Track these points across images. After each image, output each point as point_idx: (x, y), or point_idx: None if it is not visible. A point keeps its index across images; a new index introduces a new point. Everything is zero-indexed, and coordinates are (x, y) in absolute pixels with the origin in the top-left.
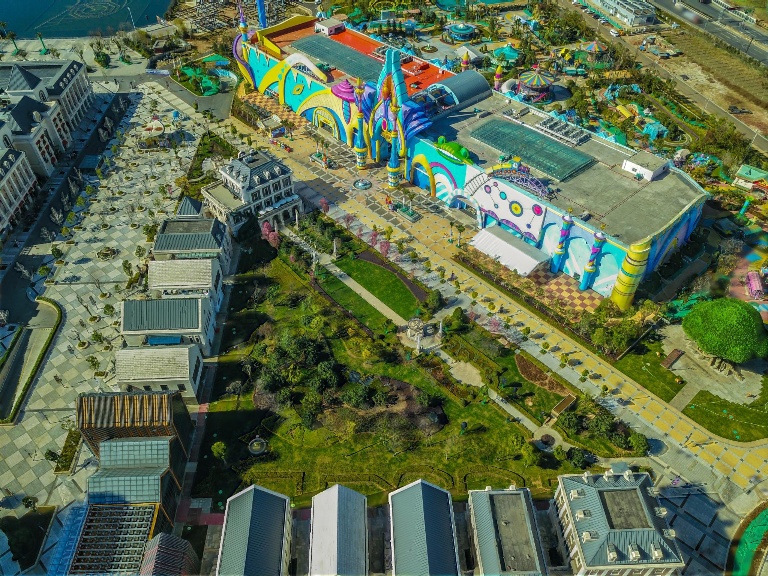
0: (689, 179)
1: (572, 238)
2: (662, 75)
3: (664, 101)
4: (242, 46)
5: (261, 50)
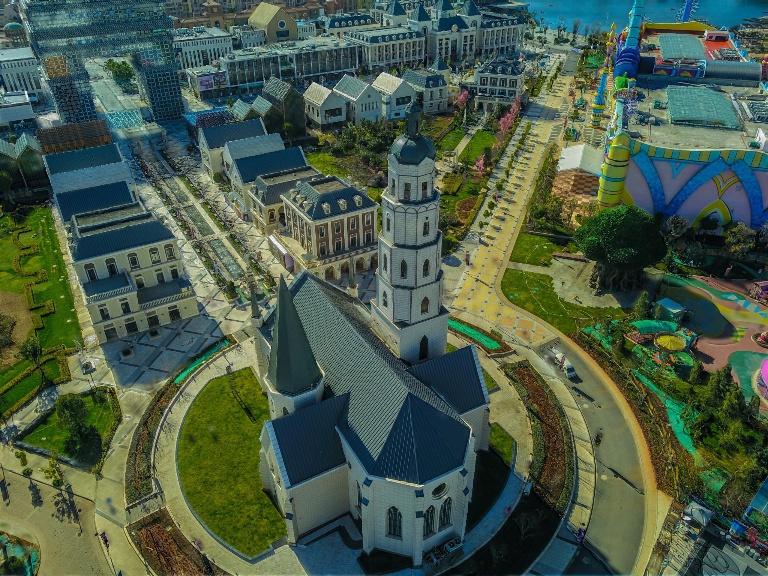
0: None
1: None
2: None
3: None
4: None
5: None
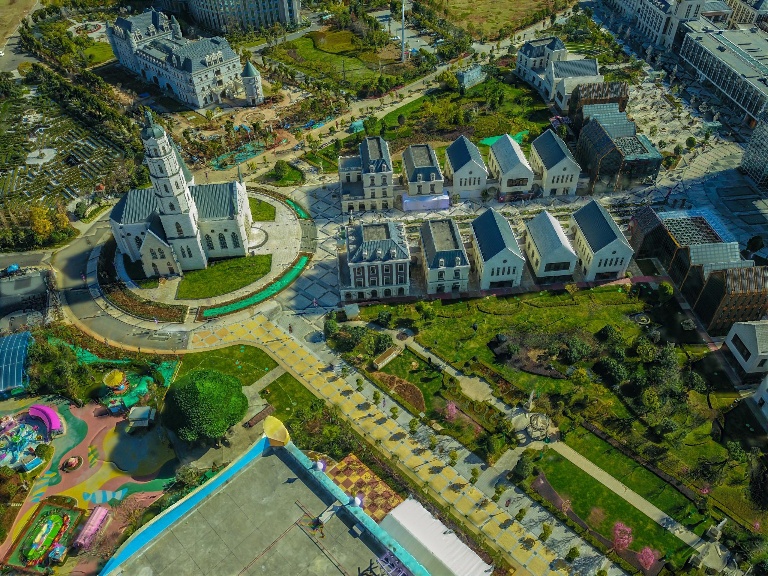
0: None
1: None
2: None
3: None
4: None
5: None
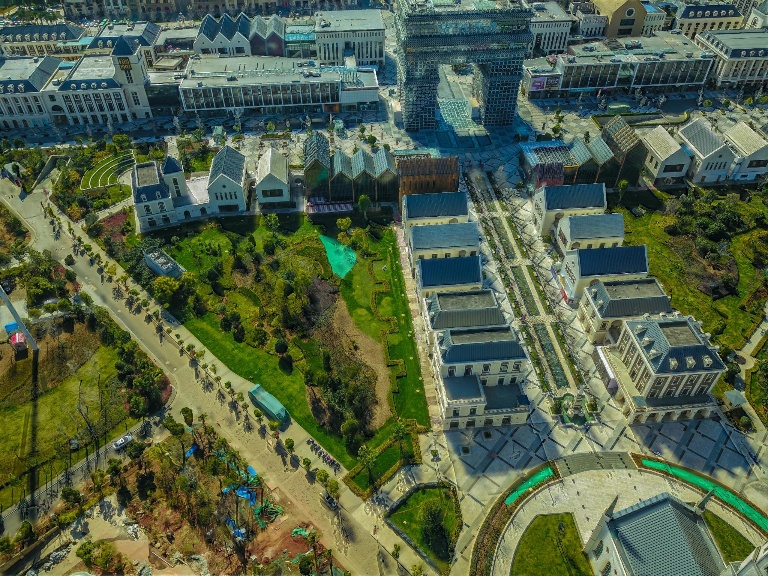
0: None
1: None
2: None
3: None
4: None
5: None
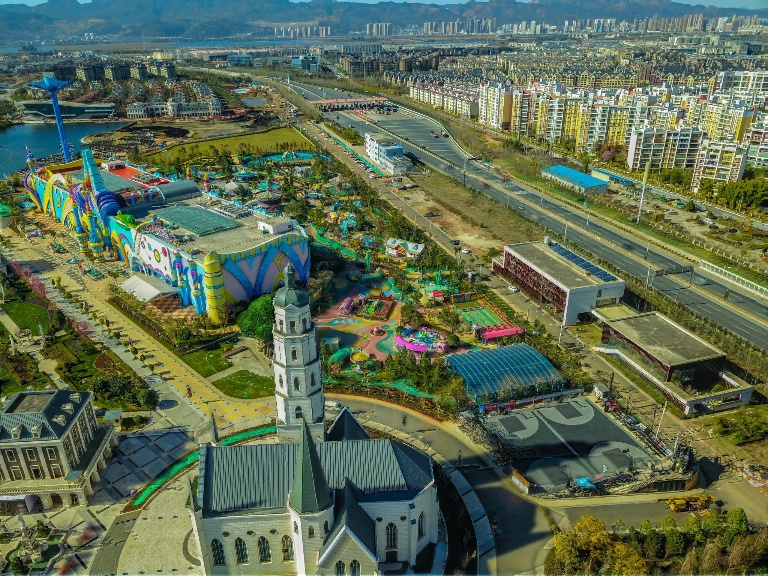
0: (301, 230)
1: (186, 270)
2: (389, 197)
3: (372, 209)
4: (30, 177)
5: (40, 177)
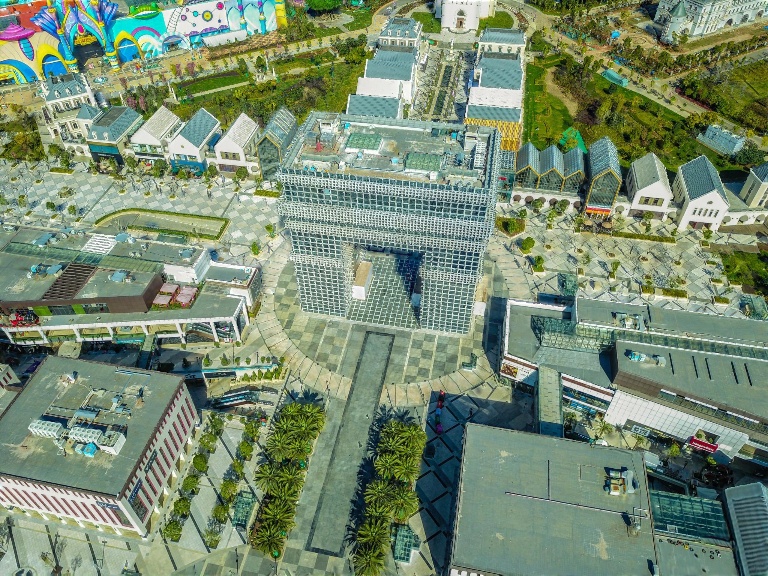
0: None
1: (244, 9)
2: None
3: None
4: None
5: None
